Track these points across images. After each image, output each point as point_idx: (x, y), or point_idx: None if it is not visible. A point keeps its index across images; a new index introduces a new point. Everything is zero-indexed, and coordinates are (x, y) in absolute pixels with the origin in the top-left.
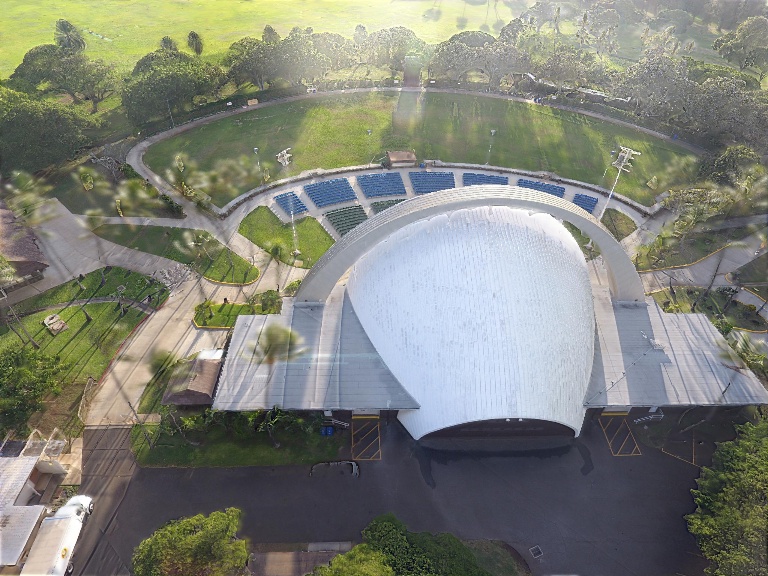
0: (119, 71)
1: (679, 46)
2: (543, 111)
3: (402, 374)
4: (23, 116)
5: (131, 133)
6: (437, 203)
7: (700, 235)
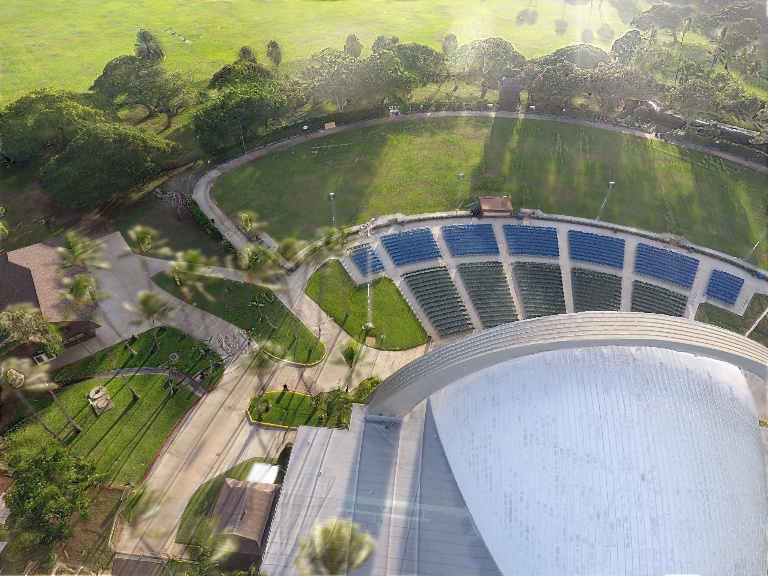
0: (196, 79)
1: None
2: (667, 150)
3: (501, 555)
4: (94, 141)
5: (202, 155)
6: (569, 336)
7: None
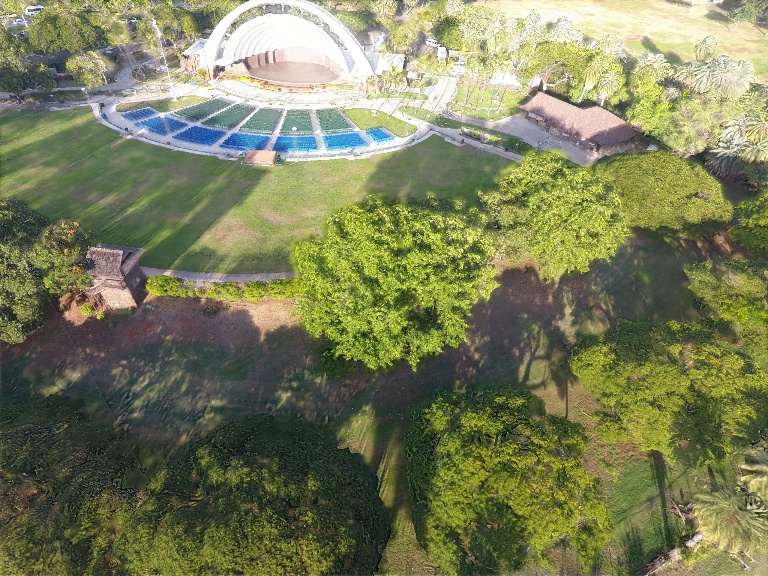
0: None
1: None
2: None
3: None
4: None
5: None
6: None
7: None
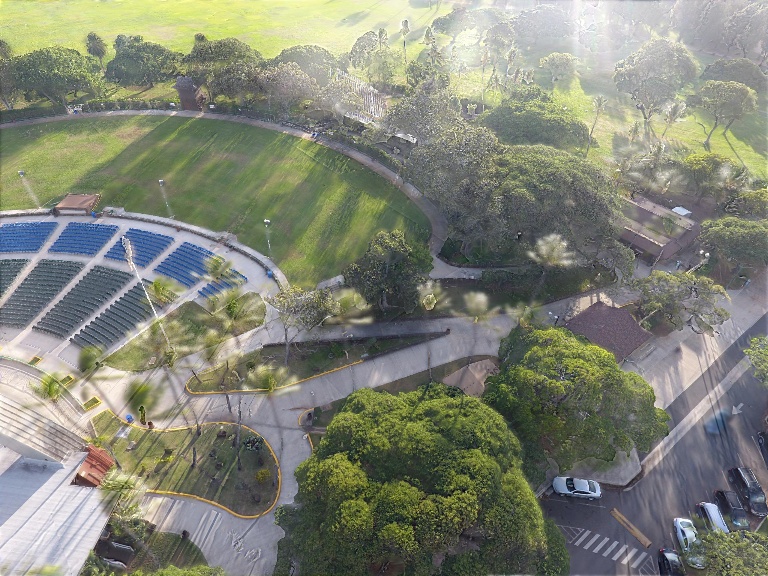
0: None
1: (520, 74)
2: (306, 150)
3: None
4: None
5: None
6: None
7: (328, 344)
